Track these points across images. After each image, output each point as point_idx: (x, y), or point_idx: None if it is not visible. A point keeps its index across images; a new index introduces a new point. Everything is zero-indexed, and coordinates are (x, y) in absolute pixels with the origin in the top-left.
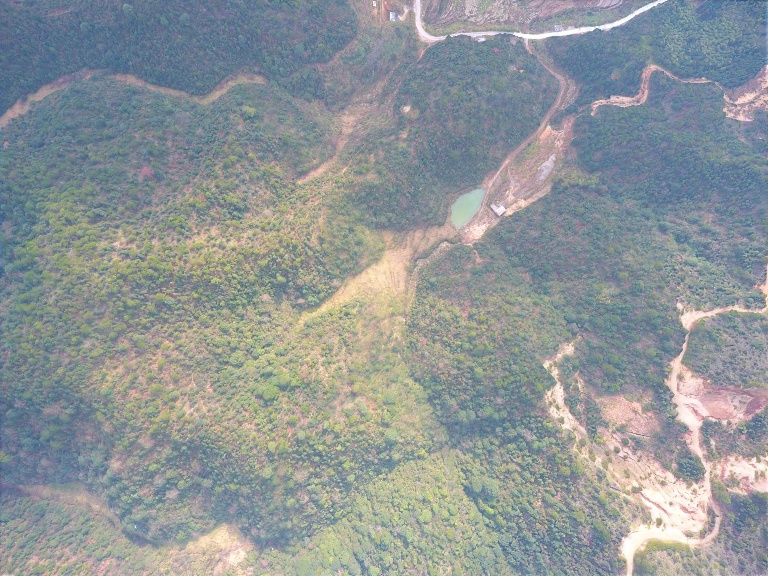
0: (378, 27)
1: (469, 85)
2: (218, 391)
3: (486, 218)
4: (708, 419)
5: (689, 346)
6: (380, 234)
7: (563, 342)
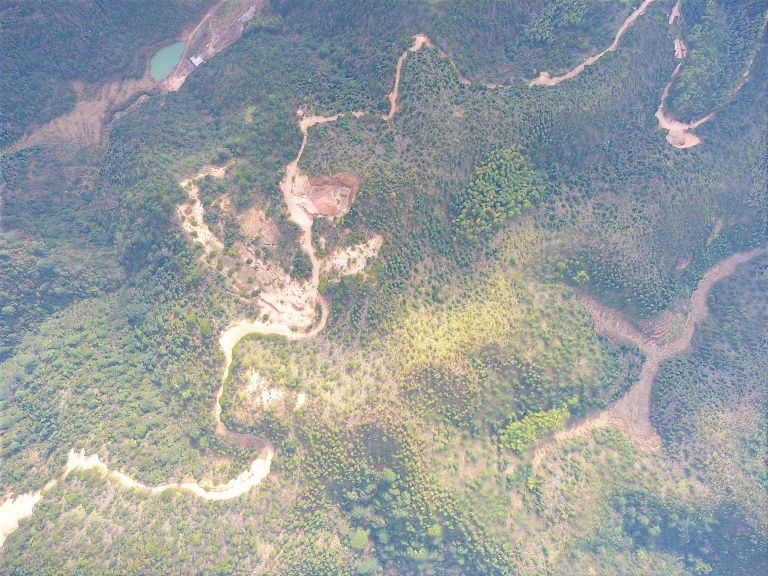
0: None
1: None
2: None
3: (185, 70)
4: (317, 216)
5: None
6: (70, 85)
7: (210, 164)
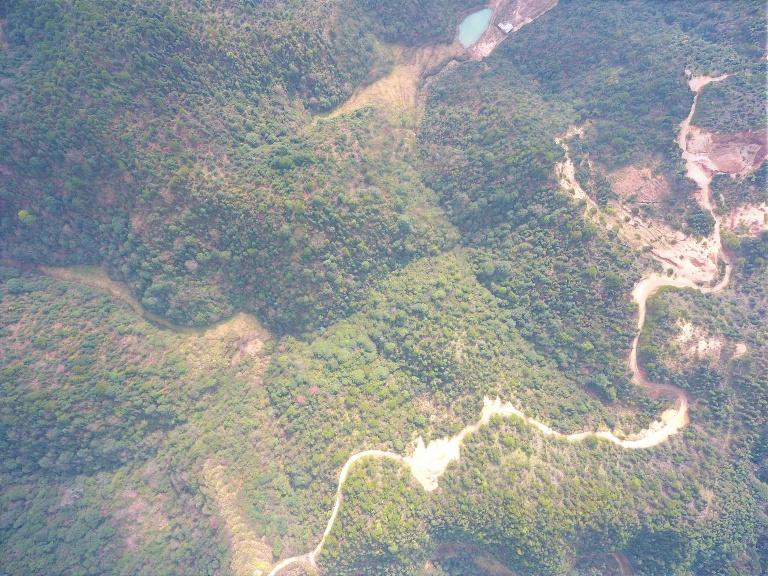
0: None
1: None
2: (235, 162)
3: (494, 36)
4: (717, 174)
5: (697, 107)
6: (389, 48)
7: (572, 124)
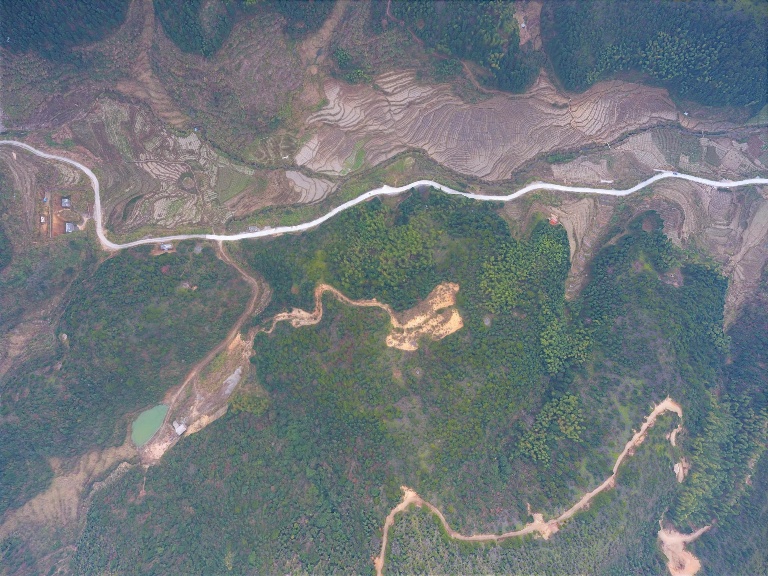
0: (43, 246)
1: (115, 321)
2: None
3: (168, 436)
4: None
5: None
6: (47, 462)
7: None
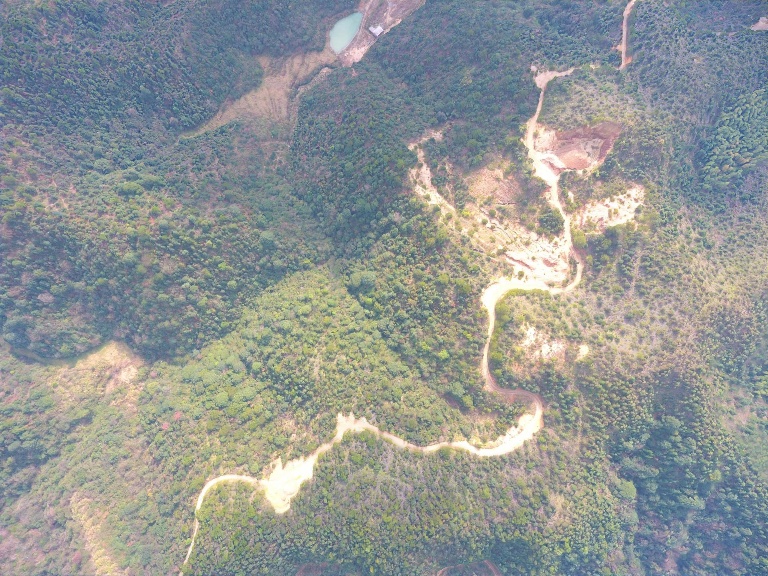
0: None
1: None
2: (81, 191)
3: (365, 41)
4: (564, 171)
5: (543, 103)
6: (257, 61)
7: (429, 128)
